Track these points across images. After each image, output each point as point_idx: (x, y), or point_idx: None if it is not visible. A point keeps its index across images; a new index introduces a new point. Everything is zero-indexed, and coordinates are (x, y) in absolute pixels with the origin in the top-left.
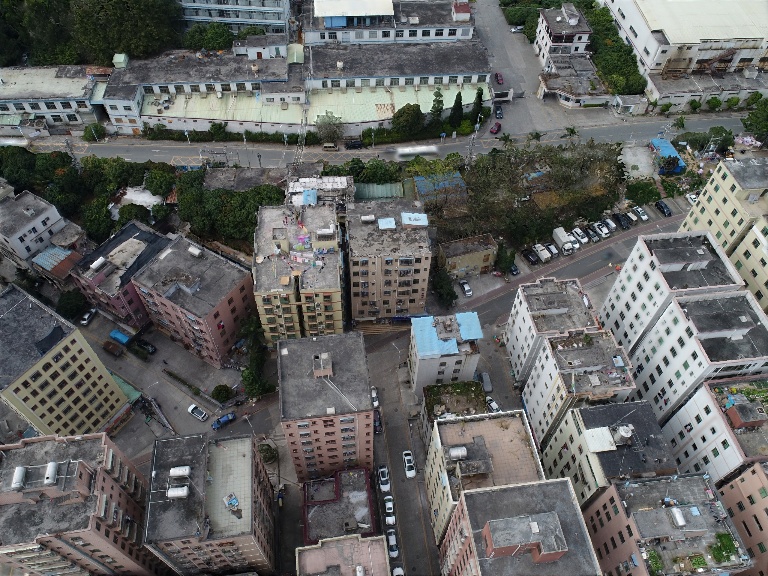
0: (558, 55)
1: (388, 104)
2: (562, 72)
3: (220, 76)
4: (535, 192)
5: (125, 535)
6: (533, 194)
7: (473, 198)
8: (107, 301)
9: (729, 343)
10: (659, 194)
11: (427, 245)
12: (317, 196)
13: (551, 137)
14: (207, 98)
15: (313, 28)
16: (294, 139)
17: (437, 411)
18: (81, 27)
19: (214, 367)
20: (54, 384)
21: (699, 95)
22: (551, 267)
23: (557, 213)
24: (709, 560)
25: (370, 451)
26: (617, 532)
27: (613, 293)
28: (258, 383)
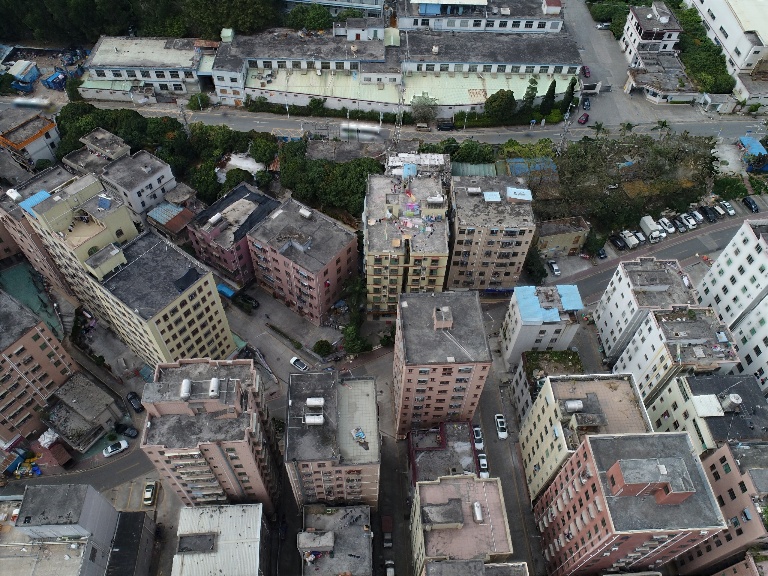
0: (646, 52)
1: (480, 89)
2: (650, 68)
3: (321, 54)
4: (624, 181)
5: (262, 456)
6: (622, 183)
7: (565, 182)
8: (219, 255)
9: None
10: (746, 191)
11: (531, 219)
12: (416, 170)
13: (638, 130)
14: (307, 75)
15: (407, 14)
16: (389, 118)
17: (536, 375)
18: (193, 2)
19: (313, 324)
20: (185, 321)
21: None
22: (638, 253)
23: (644, 202)
24: None
25: (474, 406)
26: (727, 490)
27: (709, 277)
28: (360, 340)
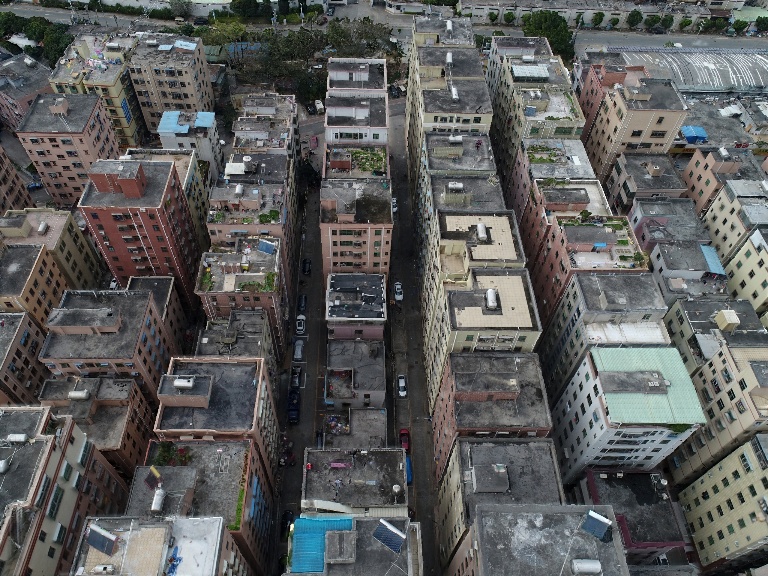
0: None
1: None
2: None
3: None
4: None
5: None
6: None
7: None
8: None
9: (352, 120)
10: None
11: (188, 63)
12: None
13: None
14: None
15: None
16: (153, 12)
17: None
18: None
19: None
20: None
21: (497, 9)
22: None
23: None
24: (257, 221)
25: None
26: None
27: None
28: None
